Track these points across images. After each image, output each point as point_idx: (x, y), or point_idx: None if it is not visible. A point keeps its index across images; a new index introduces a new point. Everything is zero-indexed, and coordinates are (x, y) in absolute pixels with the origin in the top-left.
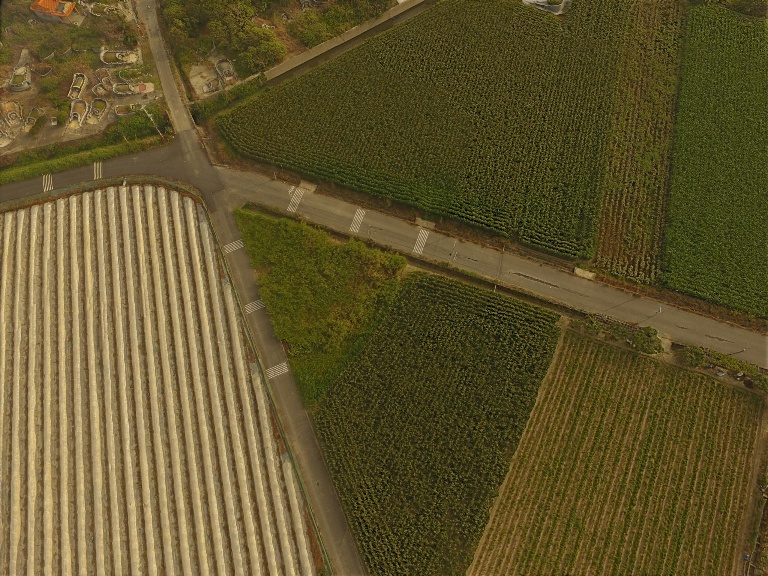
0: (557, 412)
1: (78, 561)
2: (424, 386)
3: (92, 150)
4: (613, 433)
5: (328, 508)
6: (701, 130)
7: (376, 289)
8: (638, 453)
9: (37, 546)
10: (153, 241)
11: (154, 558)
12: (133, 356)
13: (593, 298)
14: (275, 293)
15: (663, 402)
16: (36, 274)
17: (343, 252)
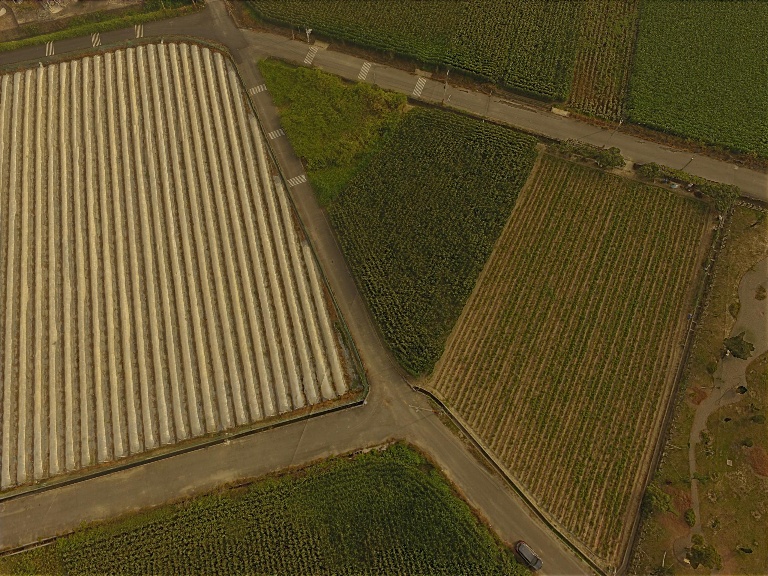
0: (534, 213)
1: (134, 314)
2: (422, 189)
3: (133, 15)
4: (581, 229)
5: (341, 278)
6: (665, 3)
7: (381, 119)
8: (602, 243)
9: (100, 303)
10: (189, 84)
11: (197, 311)
12: (175, 169)
13: (567, 130)
14: (294, 122)
15: (624, 207)
16: (89, 108)
17: (352, 91)
